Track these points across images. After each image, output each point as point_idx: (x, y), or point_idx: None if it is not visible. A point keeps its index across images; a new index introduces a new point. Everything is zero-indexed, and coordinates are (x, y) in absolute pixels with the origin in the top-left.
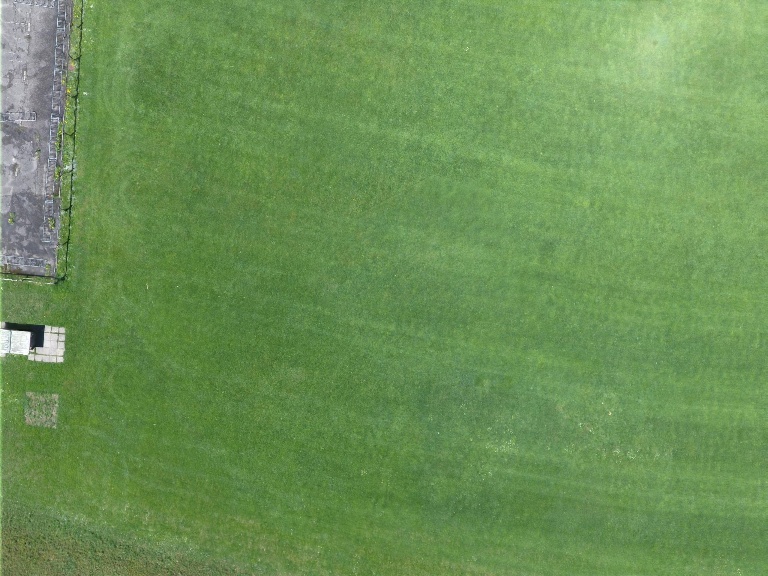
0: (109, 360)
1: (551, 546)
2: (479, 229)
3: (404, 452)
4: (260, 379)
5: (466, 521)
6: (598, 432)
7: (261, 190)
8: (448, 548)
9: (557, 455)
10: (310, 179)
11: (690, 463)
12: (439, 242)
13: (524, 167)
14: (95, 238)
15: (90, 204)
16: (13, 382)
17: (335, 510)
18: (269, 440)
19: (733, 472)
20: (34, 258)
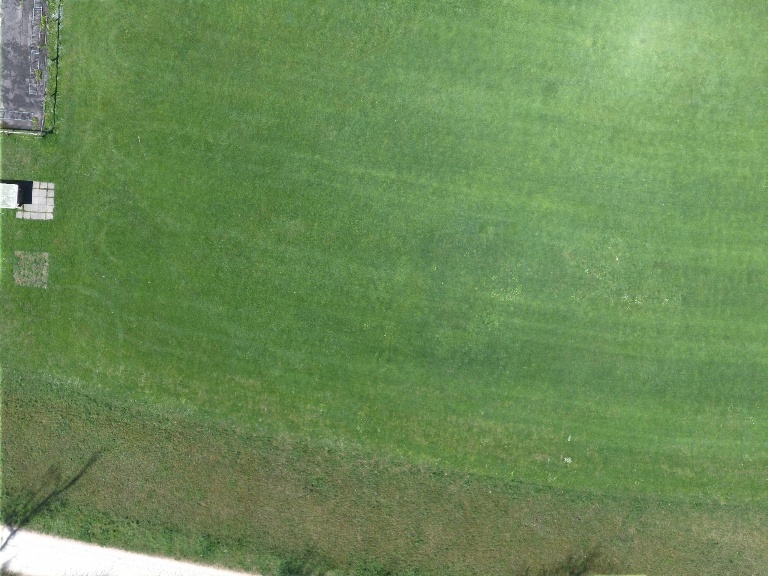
0: (101, 216)
1: (560, 396)
2: (480, 70)
3: (407, 304)
4: (258, 232)
5: (472, 373)
6: (605, 278)
7: (255, 35)
8: (454, 402)
9: (564, 303)
10: (306, 23)
11: (699, 307)
12: (439, 85)
13: (525, 5)
14: (84, 89)
15: (78, 54)
16: (1, 241)
17: (337, 366)
18: (268, 295)
19: (743, 315)
20: (20, 111)
